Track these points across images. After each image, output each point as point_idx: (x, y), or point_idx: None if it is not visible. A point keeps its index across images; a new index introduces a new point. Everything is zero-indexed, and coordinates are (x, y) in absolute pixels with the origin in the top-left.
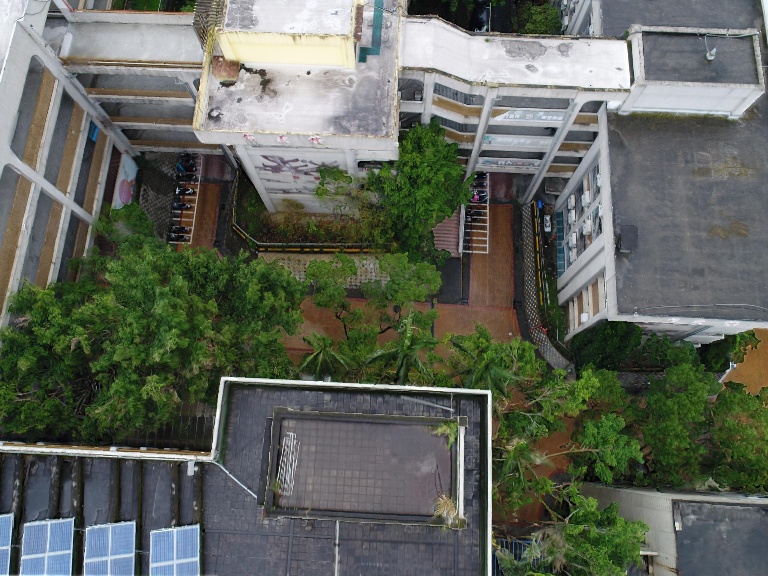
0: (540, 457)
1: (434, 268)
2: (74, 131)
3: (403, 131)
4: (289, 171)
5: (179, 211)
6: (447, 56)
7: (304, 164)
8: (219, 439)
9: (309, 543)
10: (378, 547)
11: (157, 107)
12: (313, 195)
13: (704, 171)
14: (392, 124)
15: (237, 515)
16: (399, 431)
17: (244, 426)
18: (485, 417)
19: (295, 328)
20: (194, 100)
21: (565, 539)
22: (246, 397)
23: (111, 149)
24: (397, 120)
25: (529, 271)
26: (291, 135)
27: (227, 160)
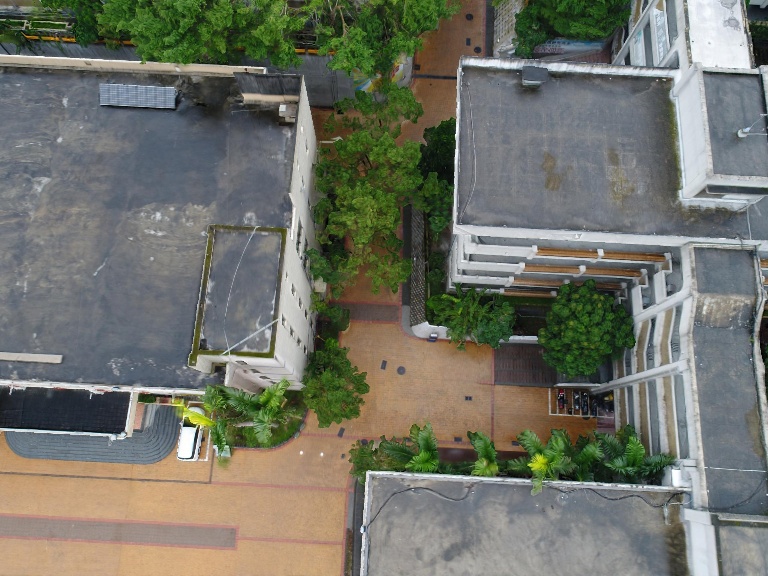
0: None
1: None
2: None
3: None
4: None
5: None
6: None
7: None
8: None
9: None
10: None
11: None
12: None
13: (614, 159)
14: None
15: None
16: None
17: None
18: None
19: None
20: None
21: None
22: None
23: None
24: None
25: None
26: None
27: None
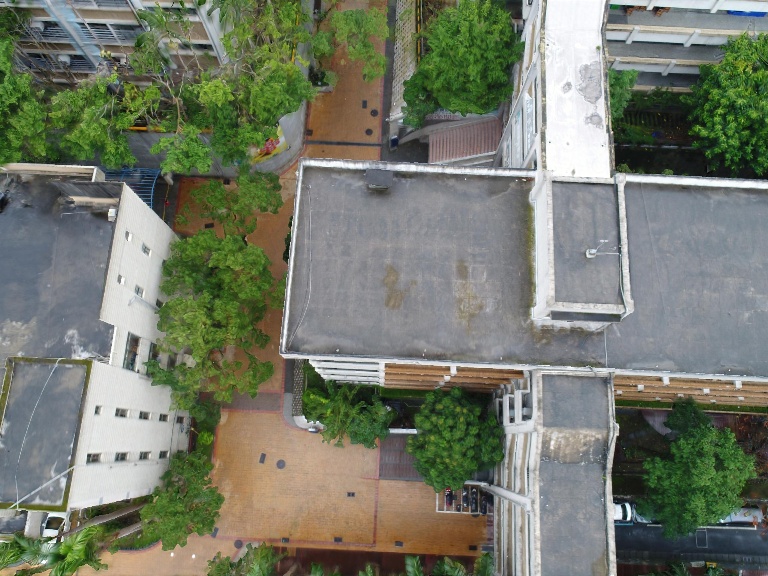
0: (152, 31)
1: (380, 72)
2: None
3: (509, 17)
4: None
5: None
6: (569, 1)
7: None
8: None
9: None
10: None
11: None
12: None
13: (463, 272)
14: None
15: None
16: None
17: None
18: None
19: None
20: None
21: None
22: None
23: None
24: None
25: None
26: None
27: None
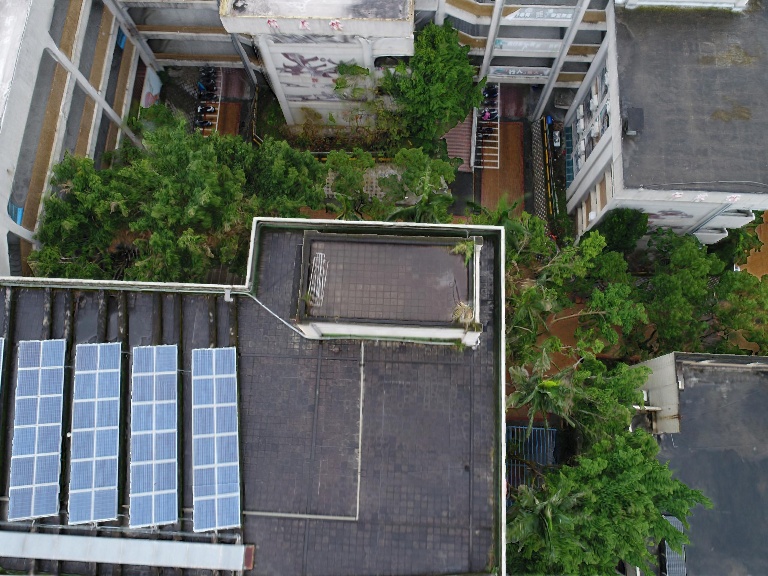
0: None
1: None
2: (104, 33)
3: (417, 31)
4: (308, 73)
5: (201, 129)
6: None
7: (323, 63)
8: (252, 273)
9: (336, 364)
10: (400, 367)
11: (182, 13)
12: (331, 102)
13: (708, 60)
14: (408, 11)
15: (270, 341)
16: (420, 251)
17: (275, 264)
18: (498, 253)
19: (318, 203)
20: (218, 2)
21: (573, 385)
22: (276, 239)
23: (137, 59)
24: (412, 15)
25: (539, 184)
26: (312, 20)
27: (247, 75)
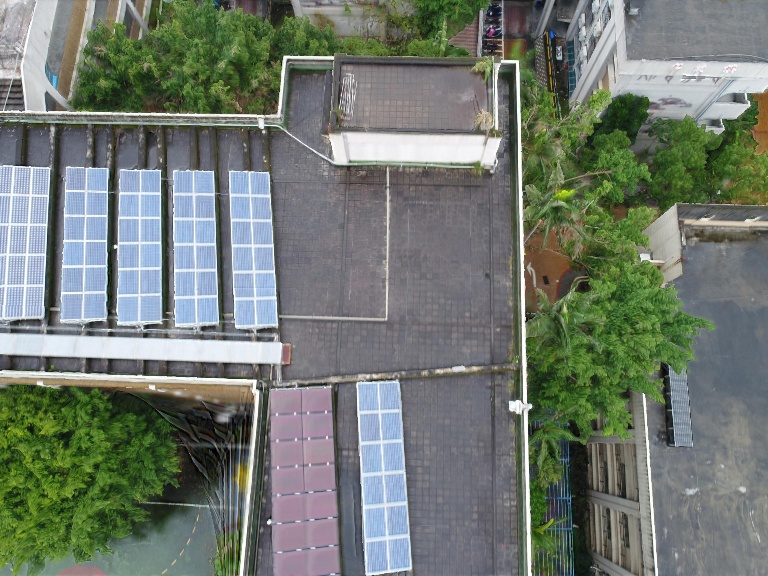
0: None
1: None
2: None
3: None
4: None
5: None
6: None
7: None
8: (283, 107)
9: (364, 188)
10: (423, 189)
11: None
12: (343, 7)
13: None
14: None
15: (300, 169)
16: (442, 71)
17: (303, 102)
18: (513, 88)
19: None
20: None
21: (582, 230)
22: (304, 80)
23: None
24: None
25: None
26: None
27: None
